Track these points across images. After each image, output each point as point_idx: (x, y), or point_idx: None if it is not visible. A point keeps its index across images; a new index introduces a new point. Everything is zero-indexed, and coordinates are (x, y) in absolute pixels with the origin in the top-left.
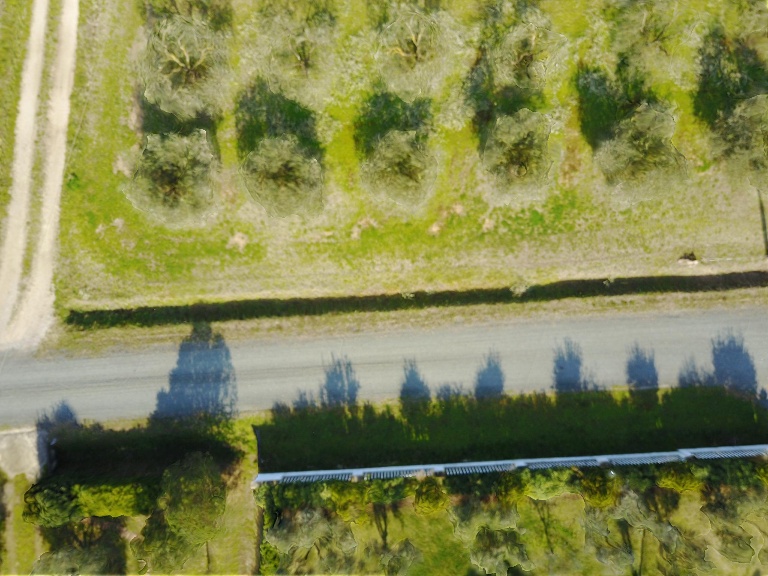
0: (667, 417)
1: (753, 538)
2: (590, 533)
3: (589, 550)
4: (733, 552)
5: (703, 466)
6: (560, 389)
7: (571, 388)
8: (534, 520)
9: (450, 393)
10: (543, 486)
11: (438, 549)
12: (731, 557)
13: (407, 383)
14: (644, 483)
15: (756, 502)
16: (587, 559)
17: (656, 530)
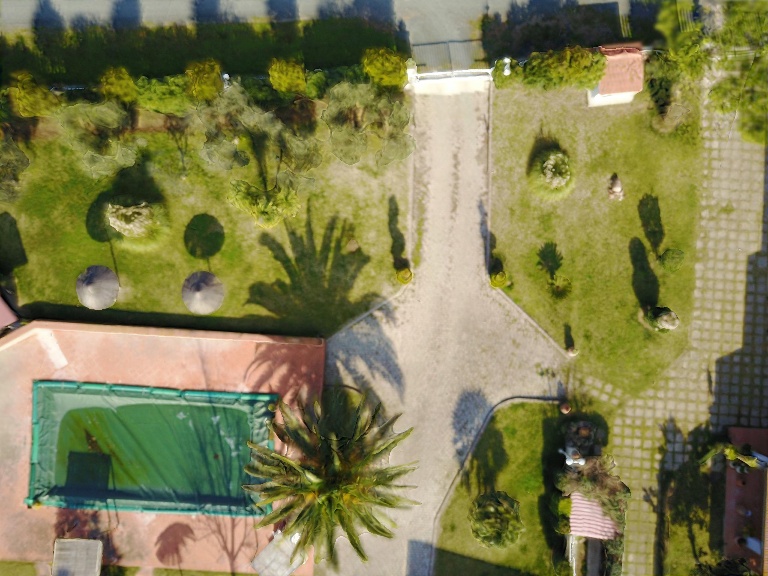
0: (309, 50)
1: (389, 164)
2: (209, 141)
3: (203, 152)
4: (337, 141)
5: (321, 71)
6: (201, 21)
7: (212, 20)
8: (171, 149)
9: (87, 24)
10: (157, 89)
11: (70, 178)
12: (339, 150)
13: (42, 13)
14: (264, 91)
15: (356, 87)
16: (222, 184)
17: (259, 118)
